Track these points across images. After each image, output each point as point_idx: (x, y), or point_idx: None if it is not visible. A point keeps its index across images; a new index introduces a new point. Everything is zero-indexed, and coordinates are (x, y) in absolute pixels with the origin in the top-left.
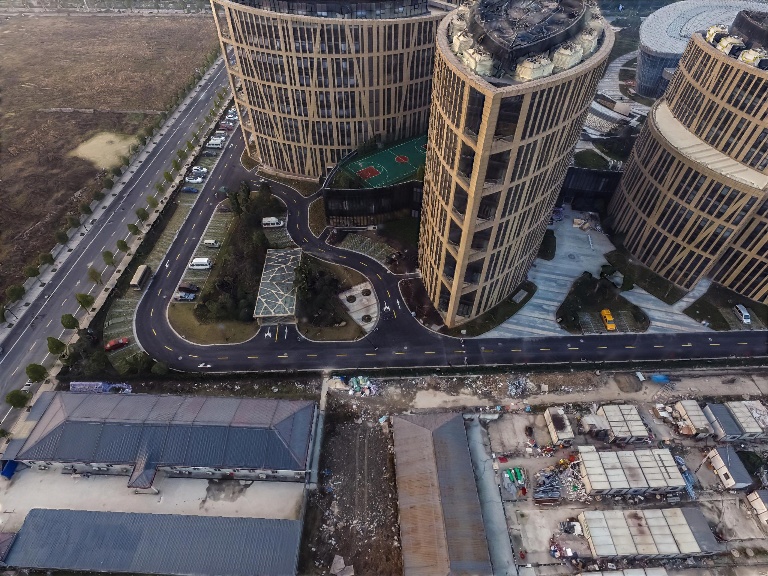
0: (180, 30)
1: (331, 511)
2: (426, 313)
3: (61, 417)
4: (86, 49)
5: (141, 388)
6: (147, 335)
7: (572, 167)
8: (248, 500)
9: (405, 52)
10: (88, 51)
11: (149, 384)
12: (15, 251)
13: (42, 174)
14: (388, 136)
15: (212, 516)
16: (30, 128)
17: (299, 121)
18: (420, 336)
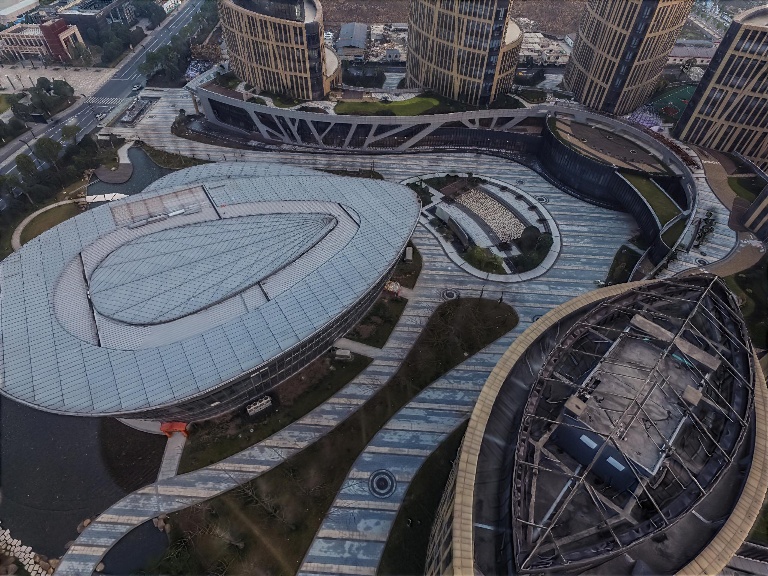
0: None
1: None
2: None
3: None
4: None
5: None
6: None
7: (551, 89)
8: None
9: None
10: None
11: None
12: None
13: None
14: None
15: None
16: None
17: None
18: None
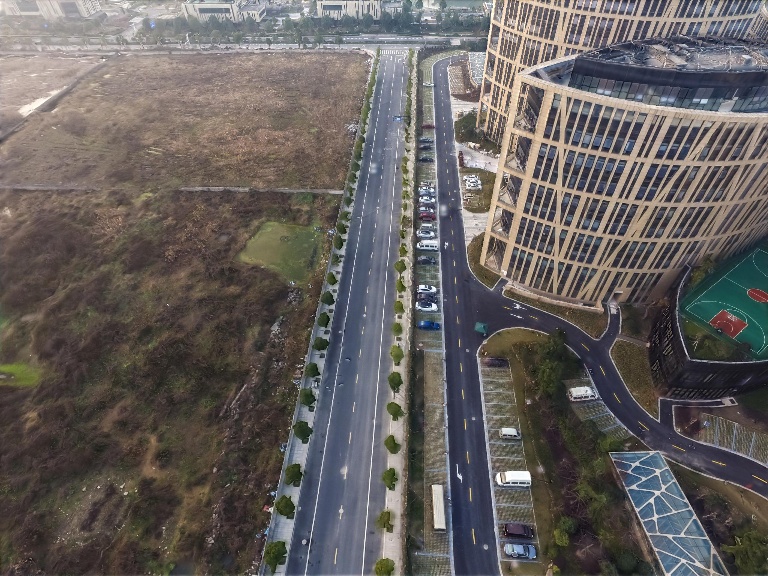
0: (304, 71)
1: None
2: None
3: None
4: (206, 99)
5: None
6: None
7: None
8: None
9: None
10: (209, 101)
11: None
12: (229, 442)
13: (220, 295)
14: (719, 255)
15: None
16: (178, 217)
17: (605, 240)
18: None
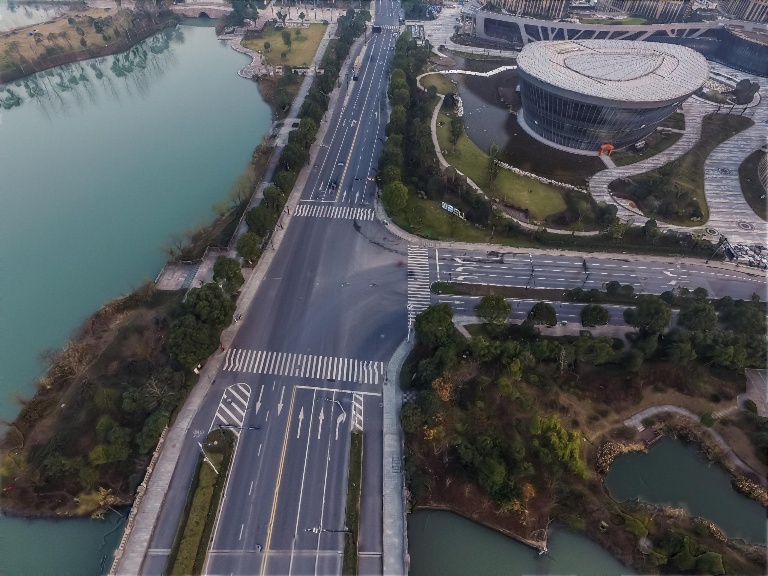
0: None
1: None
2: None
3: None
4: None
5: None
6: None
7: None
8: None
9: None
10: None
11: None
12: None
13: None
14: None
15: None
16: None
17: None
18: None
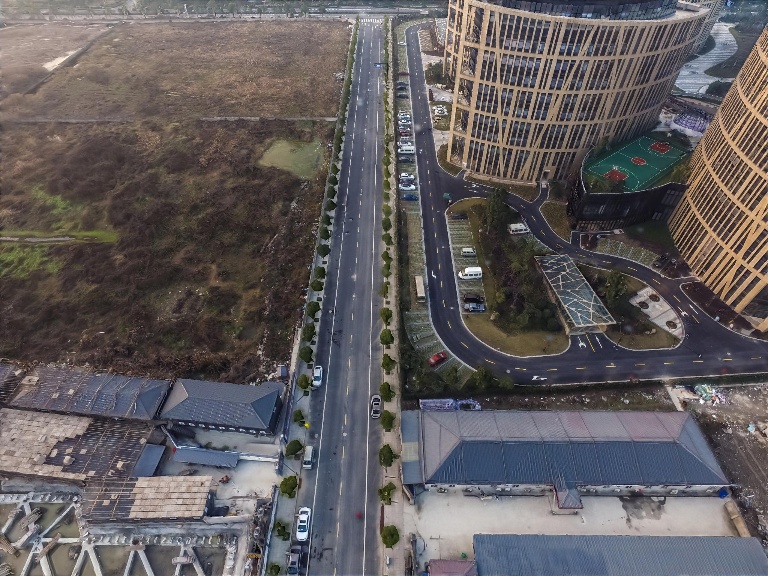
0: (293, 34)
1: (762, 526)
2: (735, 318)
3: (452, 437)
4: (211, 56)
5: (488, 404)
6: (459, 348)
7: None
8: (673, 517)
9: (662, 53)
10: (214, 58)
11: (494, 399)
12: (270, 265)
13: (248, 185)
14: (614, 138)
15: (665, 536)
16: (204, 138)
17: (533, 125)
18: (736, 341)
